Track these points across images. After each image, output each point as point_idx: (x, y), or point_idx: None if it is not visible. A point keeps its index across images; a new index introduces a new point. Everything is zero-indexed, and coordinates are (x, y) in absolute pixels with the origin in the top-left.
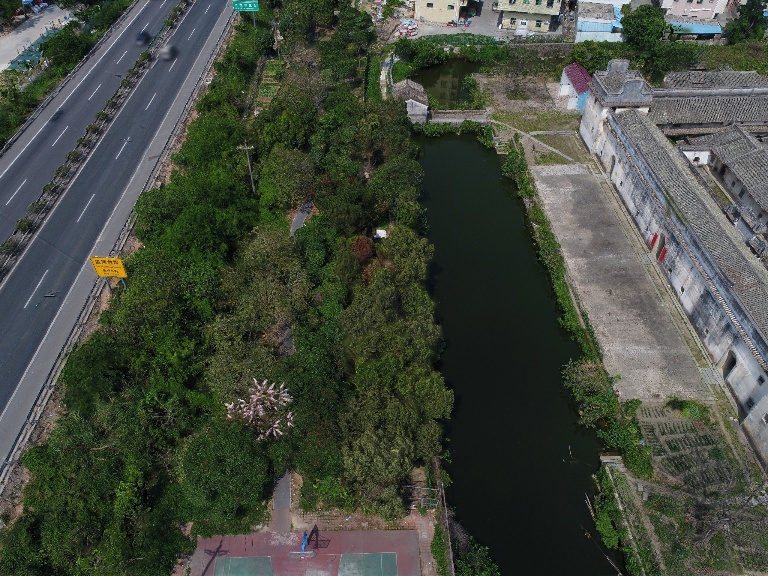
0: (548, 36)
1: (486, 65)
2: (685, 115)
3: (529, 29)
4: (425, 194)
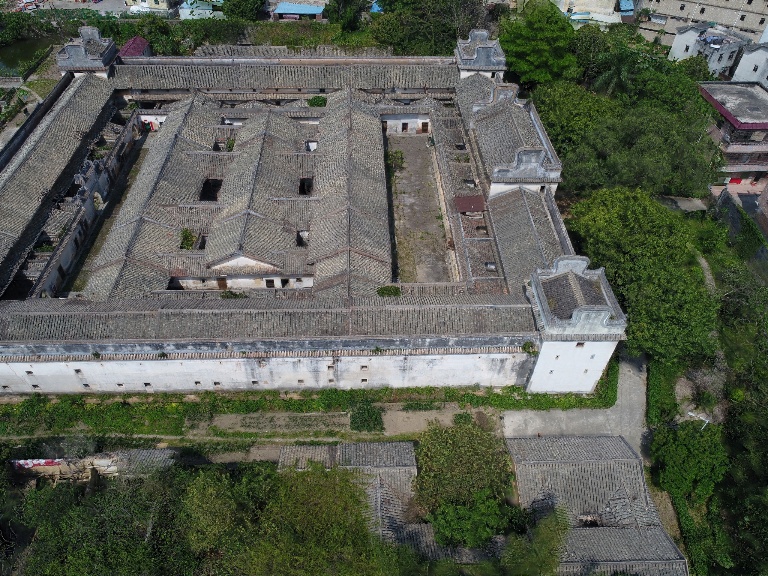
0: (153, 12)
1: None
2: (146, 81)
3: (150, 6)
4: None
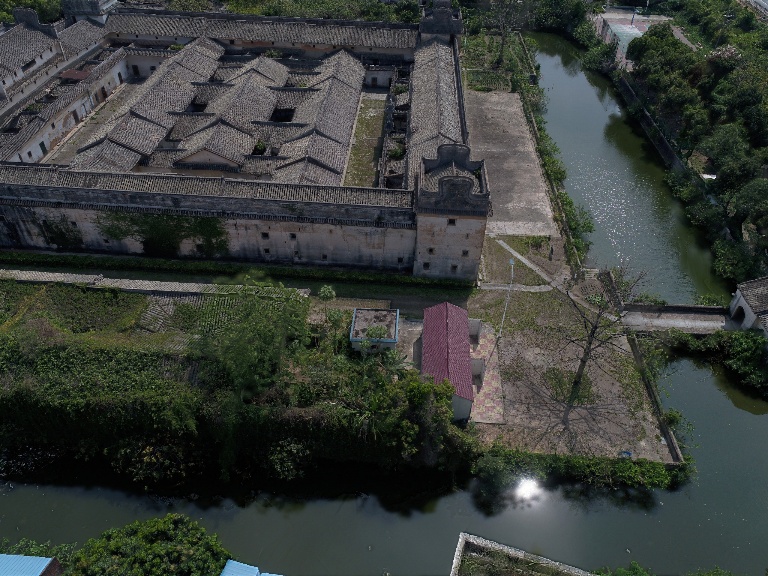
0: None
1: (651, 570)
2: None
3: None
4: (680, 220)
